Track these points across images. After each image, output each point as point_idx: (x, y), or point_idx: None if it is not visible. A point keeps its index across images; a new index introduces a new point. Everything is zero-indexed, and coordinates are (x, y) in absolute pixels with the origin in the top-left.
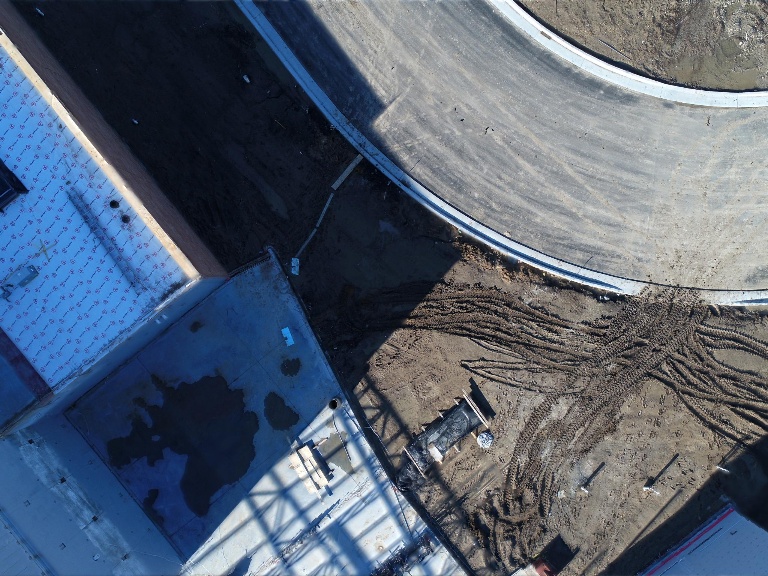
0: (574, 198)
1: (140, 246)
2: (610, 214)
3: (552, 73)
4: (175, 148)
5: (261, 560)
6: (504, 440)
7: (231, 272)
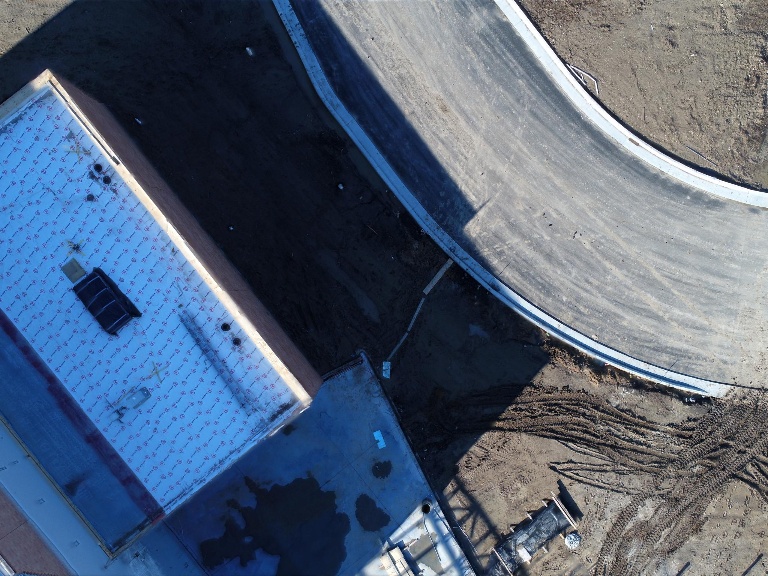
0: (661, 302)
1: (250, 368)
2: (696, 317)
3: (639, 179)
4: (269, 253)
5: None
6: (591, 541)
7: (324, 376)
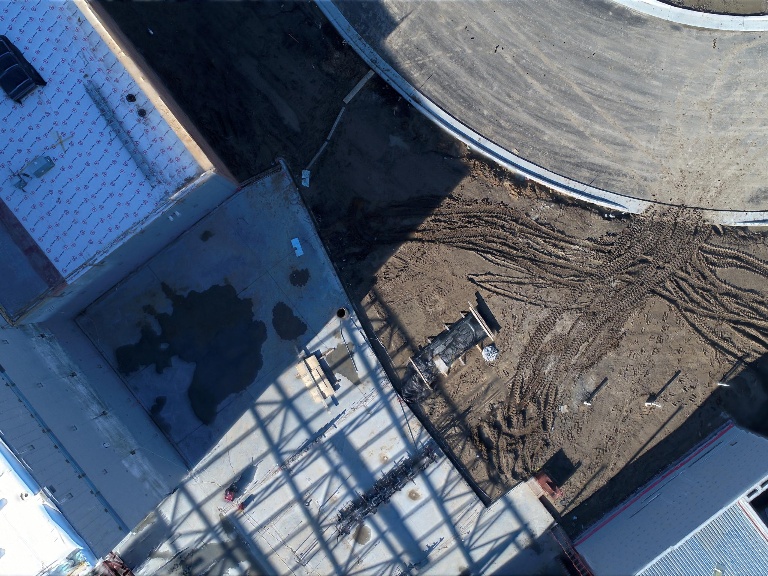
0: (581, 117)
1: (155, 140)
2: (617, 133)
3: None
4: (189, 59)
5: (267, 468)
6: (509, 354)
7: (242, 182)
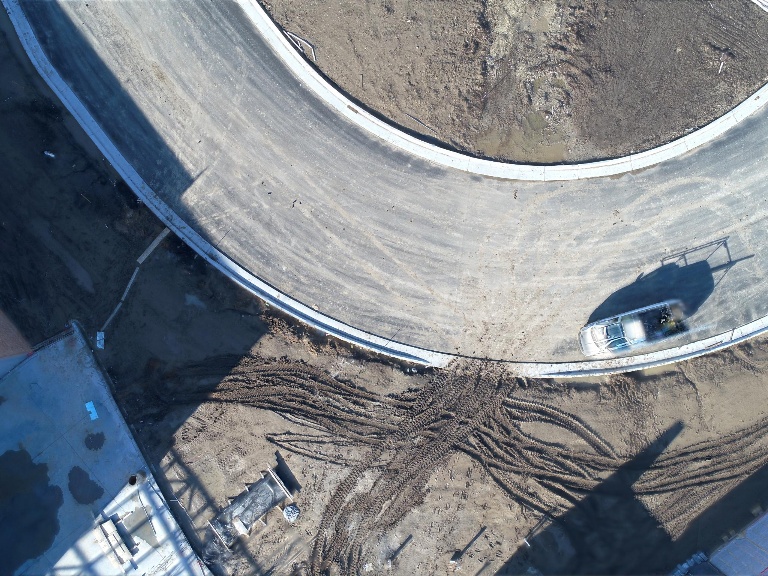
0: (382, 271)
1: None
2: (418, 287)
3: (359, 146)
4: None
5: None
6: (311, 513)
7: (35, 346)
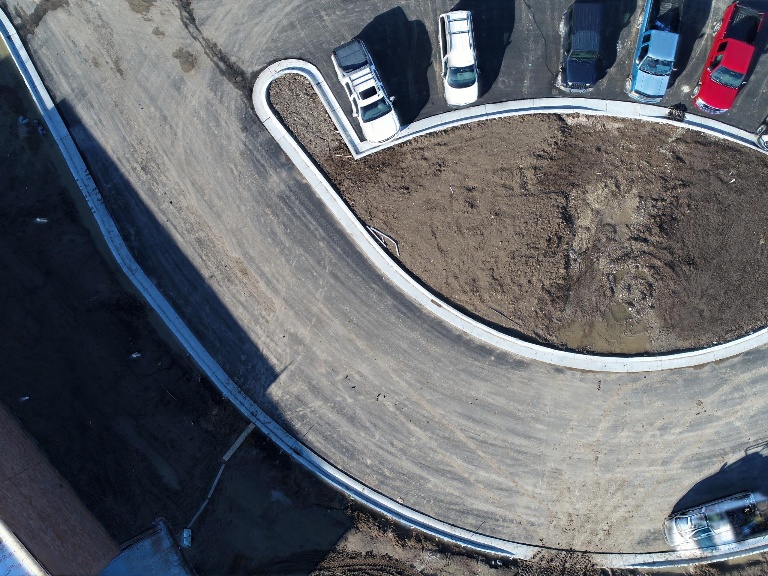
0: (466, 463)
1: (13, 566)
2: (502, 479)
3: (443, 340)
4: (66, 422)
5: None
6: None
7: (123, 544)
